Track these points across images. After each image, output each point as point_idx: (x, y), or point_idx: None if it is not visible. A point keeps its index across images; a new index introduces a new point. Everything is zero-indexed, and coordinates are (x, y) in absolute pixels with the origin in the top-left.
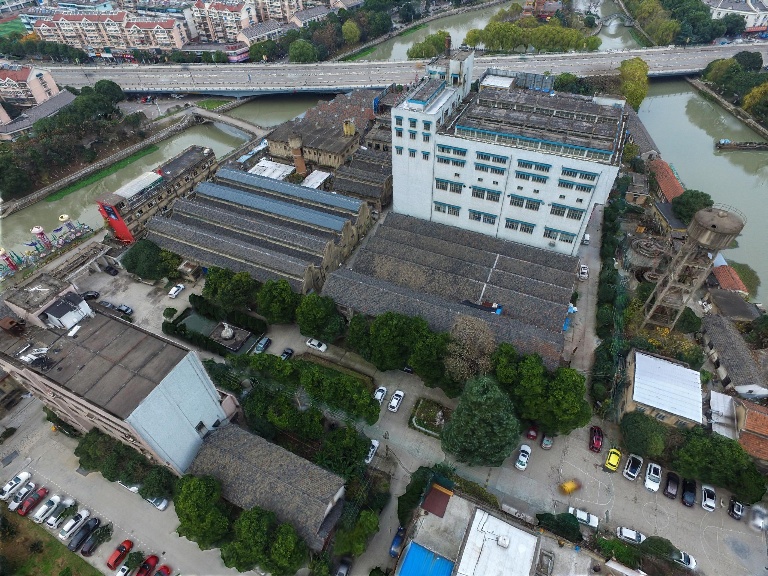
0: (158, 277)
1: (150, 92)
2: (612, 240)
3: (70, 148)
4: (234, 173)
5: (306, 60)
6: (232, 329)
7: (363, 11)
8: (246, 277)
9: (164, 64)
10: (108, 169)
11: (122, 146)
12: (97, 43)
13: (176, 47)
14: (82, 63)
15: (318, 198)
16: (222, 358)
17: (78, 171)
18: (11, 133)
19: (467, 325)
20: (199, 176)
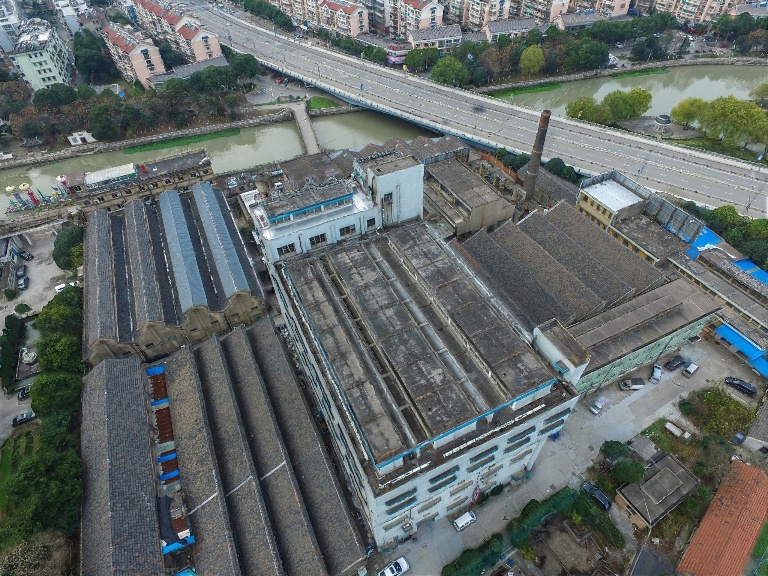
0: (61, 267)
1: (288, 75)
2: (468, 562)
3: (161, 112)
4: (202, 193)
5: (445, 82)
6: (37, 356)
7: (570, 36)
8: (59, 316)
9: (329, 49)
10: (186, 139)
11: (214, 121)
12: (300, 15)
13: (351, 34)
14: (286, 30)
15: (219, 261)
16: (0, 380)
17: (164, 133)
18: (155, 83)
19: (8, 559)
20: (185, 182)
